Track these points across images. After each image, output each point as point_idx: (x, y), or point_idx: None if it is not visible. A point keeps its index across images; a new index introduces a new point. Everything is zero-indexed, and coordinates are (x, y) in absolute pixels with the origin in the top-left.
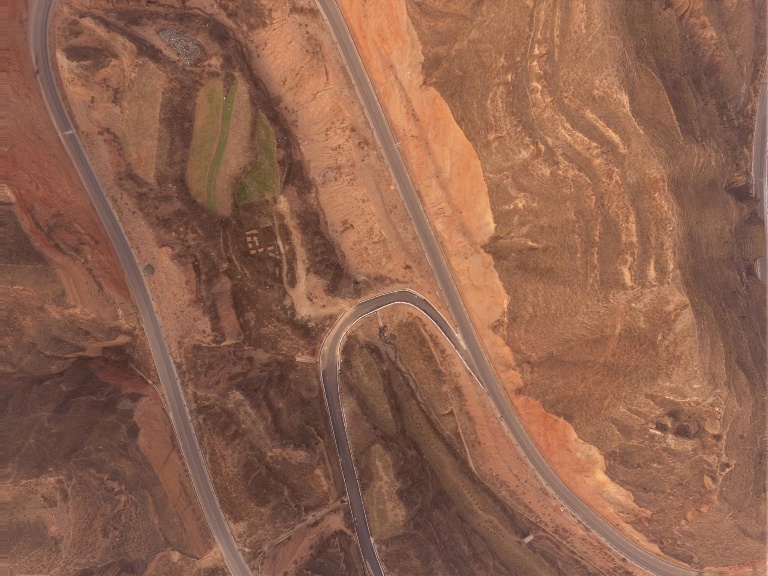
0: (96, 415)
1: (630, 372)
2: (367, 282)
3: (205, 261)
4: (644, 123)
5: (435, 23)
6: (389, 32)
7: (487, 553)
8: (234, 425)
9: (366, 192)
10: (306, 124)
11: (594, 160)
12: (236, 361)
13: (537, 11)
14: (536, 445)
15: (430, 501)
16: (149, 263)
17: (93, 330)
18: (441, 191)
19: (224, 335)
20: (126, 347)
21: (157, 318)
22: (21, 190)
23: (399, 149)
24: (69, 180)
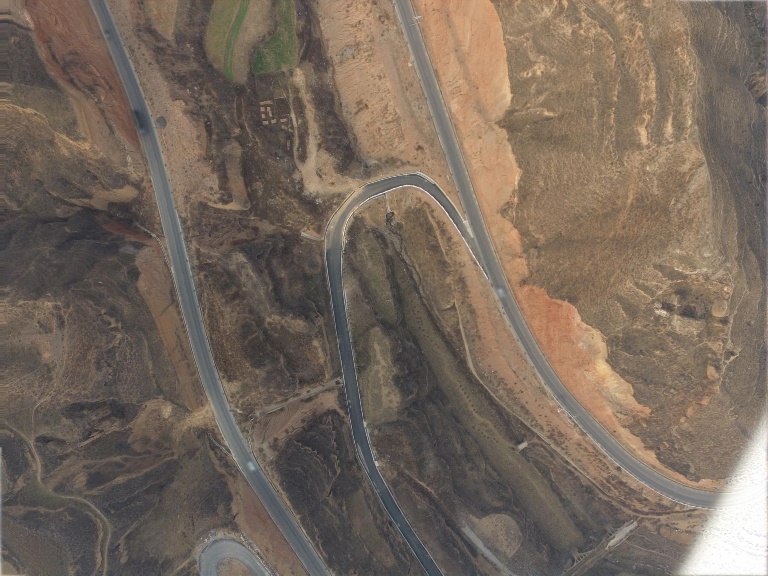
0: (98, 254)
1: (639, 242)
2: (378, 165)
3: (217, 123)
4: None
5: None
6: None
7: (480, 455)
8: (235, 287)
9: (383, 67)
10: (327, 1)
11: (617, 16)
12: (241, 228)
13: None
14: (537, 342)
15: (426, 395)
16: (161, 115)
17: (101, 173)
18: (459, 66)
19: (231, 196)
20: (132, 204)
21: (165, 171)
22: (40, 19)
23: (419, 26)
24: (88, 26)
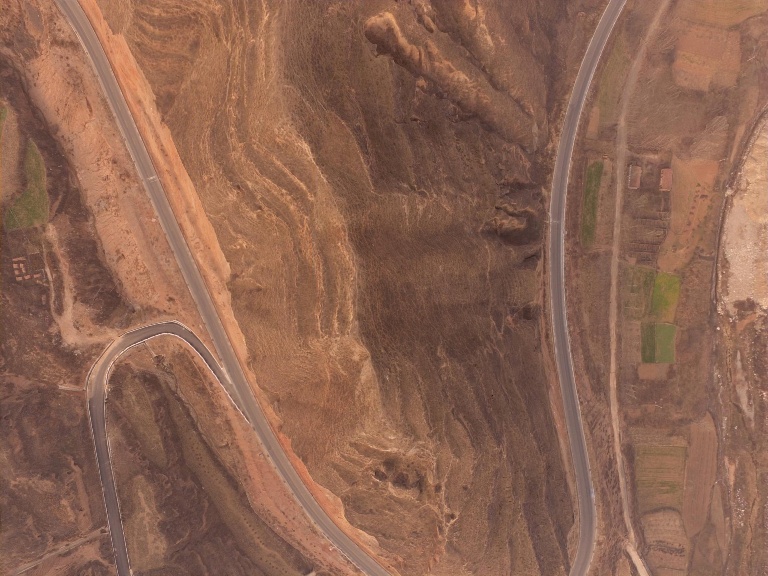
0: None
1: (338, 419)
2: (139, 312)
3: None
4: (330, 172)
5: (157, 63)
6: (128, 69)
7: None
8: None
9: (128, 224)
10: (81, 153)
11: (290, 206)
12: None
13: (233, 56)
14: (304, 482)
15: (204, 533)
16: None
17: None
18: (192, 226)
19: None
20: None
21: None
22: None
23: (161, 182)
24: None
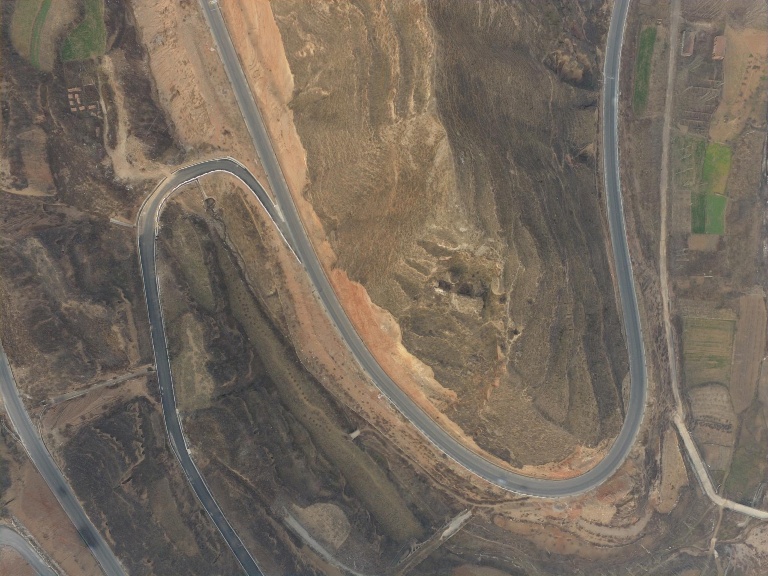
0: None
1: (405, 219)
2: (192, 151)
3: (17, 109)
4: None
5: None
6: None
7: (309, 444)
8: (29, 272)
9: (186, 53)
10: None
11: None
12: (45, 214)
13: None
14: (354, 327)
15: (249, 383)
16: None
17: None
18: (253, 49)
19: (26, 181)
20: None
21: None
22: None
23: (221, 11)
24: None
